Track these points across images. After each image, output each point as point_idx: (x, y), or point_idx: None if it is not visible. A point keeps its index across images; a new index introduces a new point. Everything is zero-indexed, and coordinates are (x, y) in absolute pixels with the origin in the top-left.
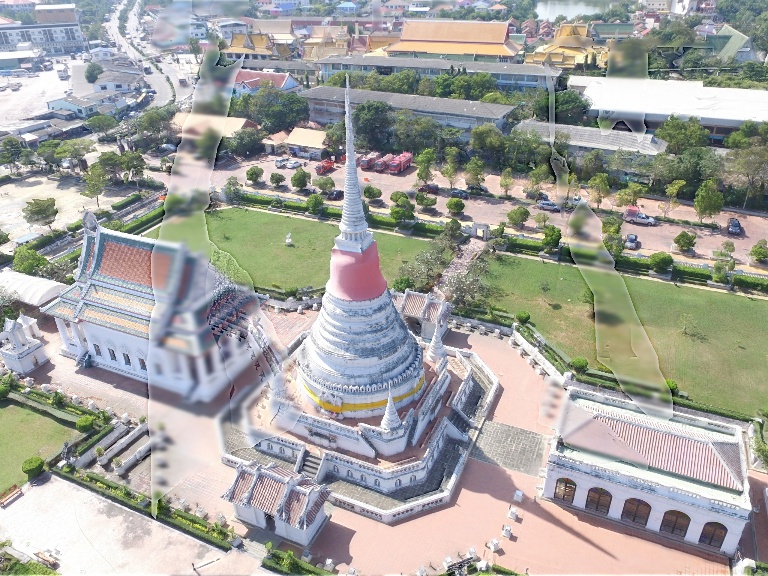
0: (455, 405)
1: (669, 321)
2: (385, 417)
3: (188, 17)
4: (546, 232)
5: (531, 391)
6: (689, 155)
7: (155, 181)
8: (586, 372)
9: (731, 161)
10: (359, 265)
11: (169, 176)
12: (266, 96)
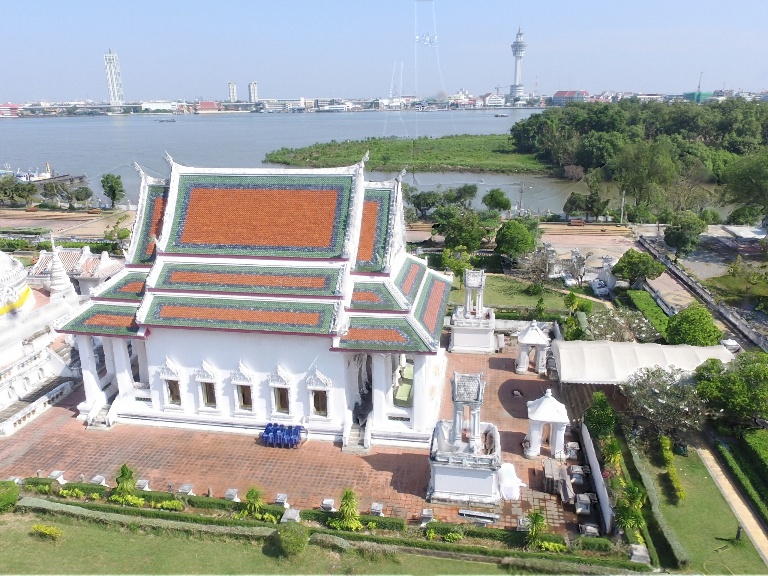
0: None
1: None
2: None
3: None
4: None
5: None
6: None
7: None
8: None
9: None
10: None
11: None
12: None
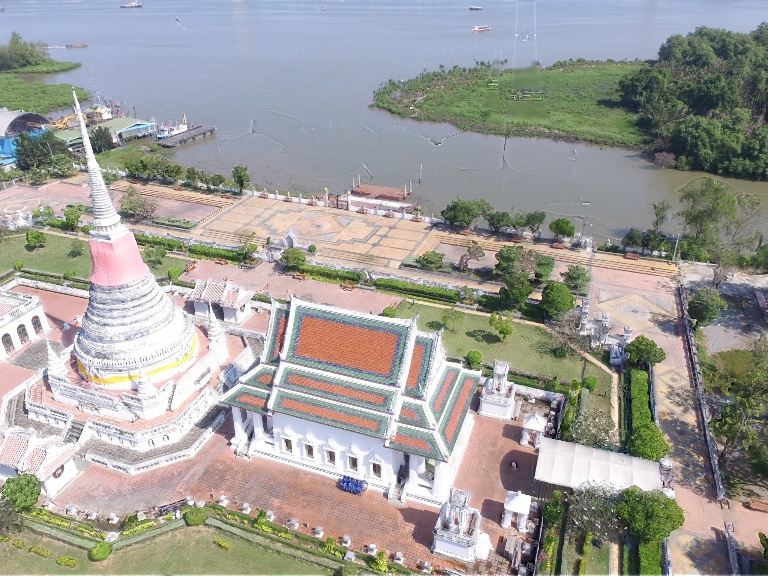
0: None
1: None
2: None
3: None
4: None
5: None
6: None
7: None
8: None
9: None
10: None
11: None
12: None
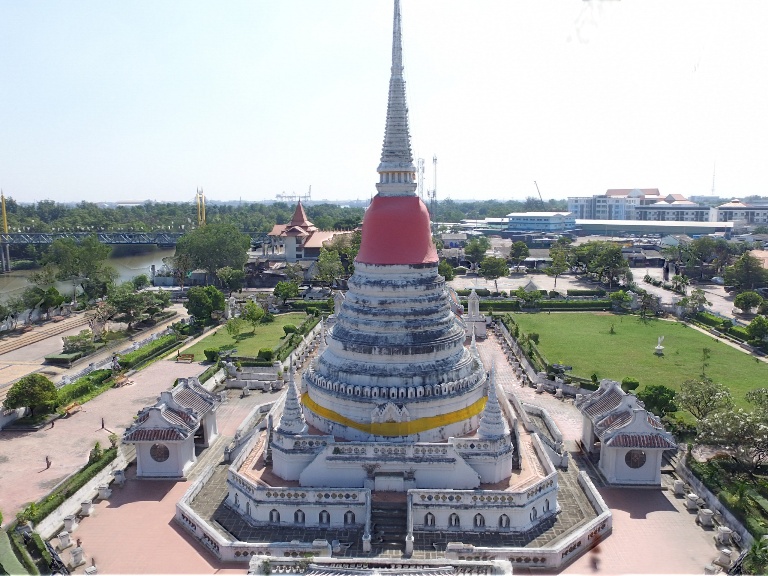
0: (410, 496)
1: None
2: None
3: None
4: None
5: None
6: None
7: (637, 287)
8: None
9: None
10: (369, 212)
11: (671, 294)
12: None
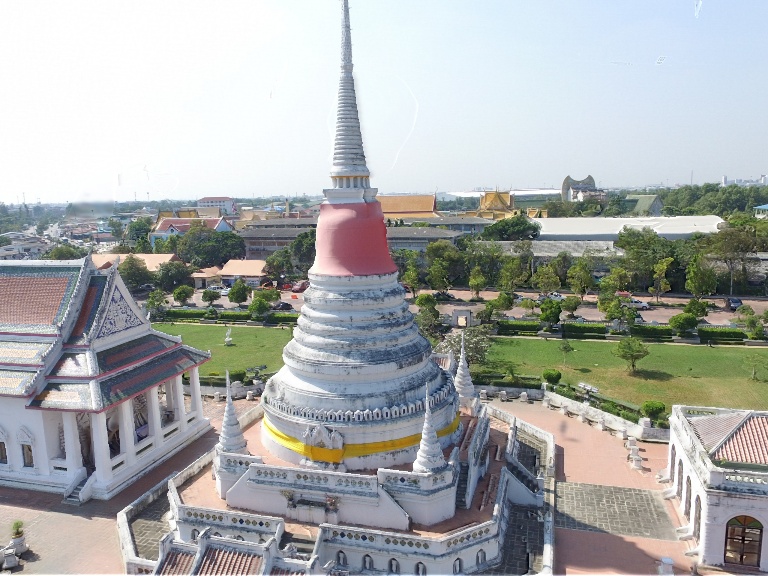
0: (511, 455)
1: (728, 372)
2: (420, 451)
3: (113, 189)
4: (542, 307)
5: (602, 447)
6: (661, 246)
7: None
8: (667, 416)
9: (705, 248)
10: (362, 220)
11: None
12: (197, 234)
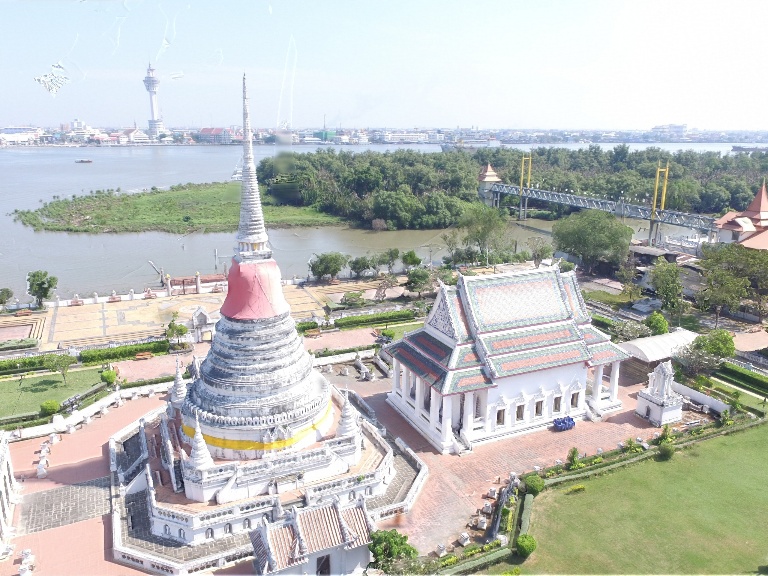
0: None
1: None
2: None
3: None
4: None
5: None
6: None
7: None
8: None
9: None
10: None
11: None
12: None
